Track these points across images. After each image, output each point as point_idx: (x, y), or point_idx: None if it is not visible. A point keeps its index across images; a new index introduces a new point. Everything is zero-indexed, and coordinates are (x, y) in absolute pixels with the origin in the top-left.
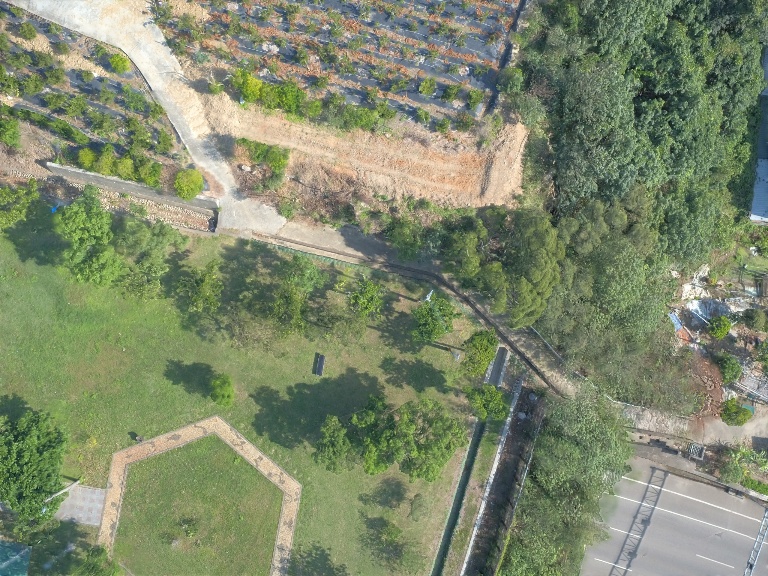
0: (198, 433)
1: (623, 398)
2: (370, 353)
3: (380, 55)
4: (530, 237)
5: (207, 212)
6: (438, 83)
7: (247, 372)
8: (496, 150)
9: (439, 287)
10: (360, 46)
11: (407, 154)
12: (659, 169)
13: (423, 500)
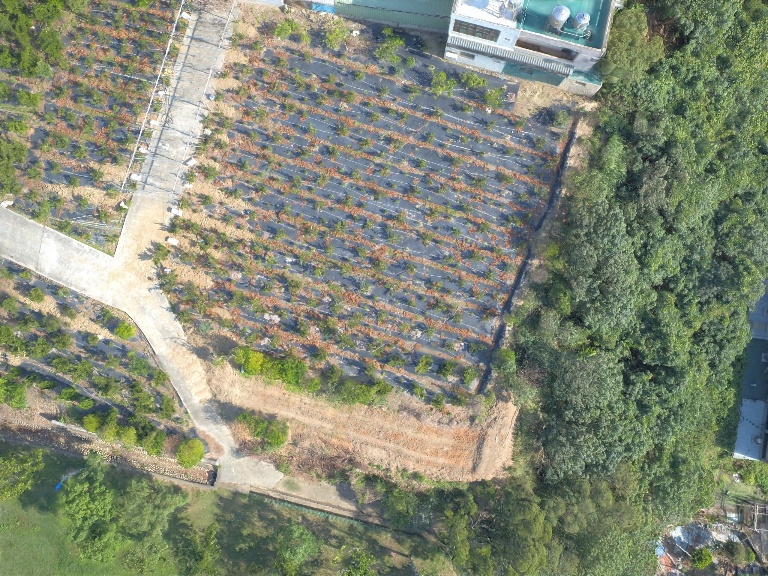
0: None
1: None
2: None
3: (378, 328)
4: (518, 525)
5: (206, 466)
6: (434, 357)
7: None
8: (488, 427)
9: (430, 540)
10: (359, 320)
11: (402, 427)
12: (645, 445)
13: None
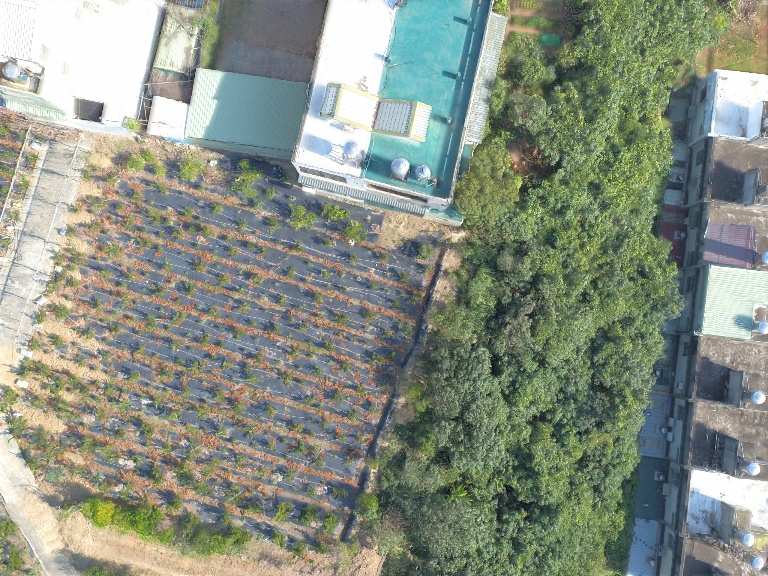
0: None
1: None
2: None
3: (238, 472)
4: None
5: None
6: (296, 501)
7: None
8: None
9: None
10: (217, 465)
11: None
12: None
13: None
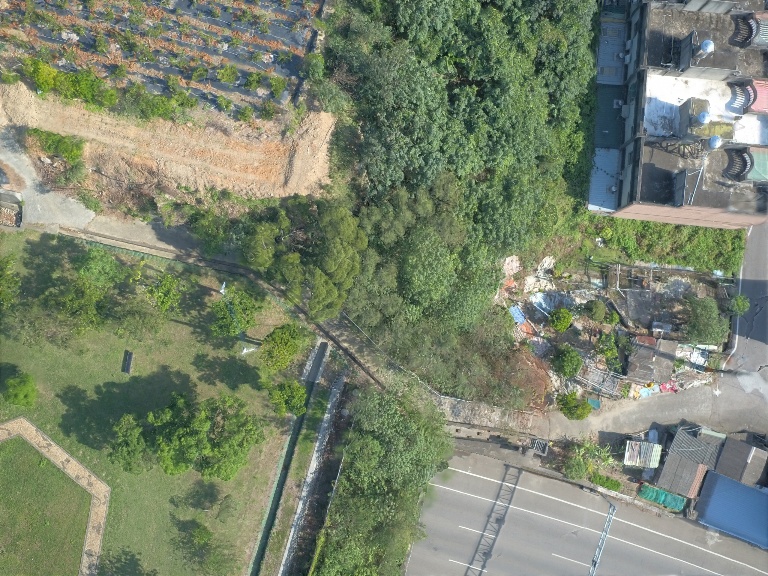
0: (2, 435)
1: (453, 393)
2: (181, 350)
3: (182, 43)
4: (326, 226)
5: (12, 206)
6: (242, 71)
7: (53, 371)
8: (299, 139)
9: (255, 281)
10: (161, 34)
11: (209, 144)
12: (469, 157)
13: (231, 501)
